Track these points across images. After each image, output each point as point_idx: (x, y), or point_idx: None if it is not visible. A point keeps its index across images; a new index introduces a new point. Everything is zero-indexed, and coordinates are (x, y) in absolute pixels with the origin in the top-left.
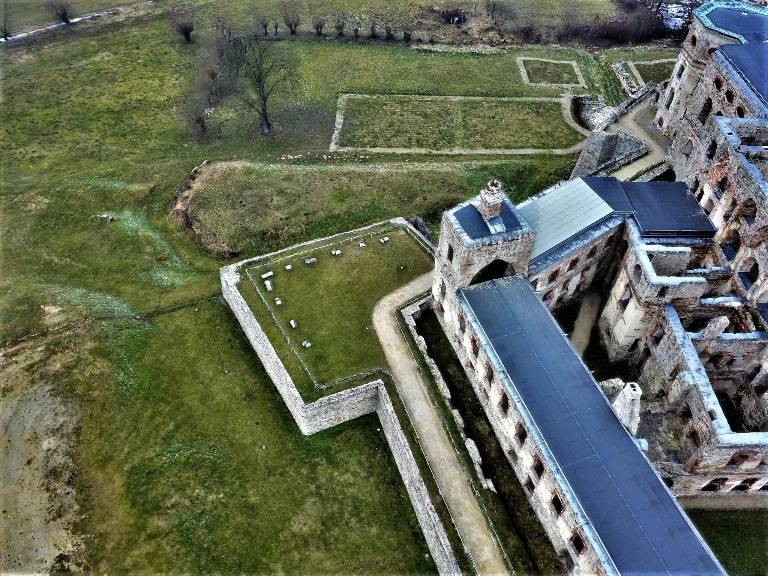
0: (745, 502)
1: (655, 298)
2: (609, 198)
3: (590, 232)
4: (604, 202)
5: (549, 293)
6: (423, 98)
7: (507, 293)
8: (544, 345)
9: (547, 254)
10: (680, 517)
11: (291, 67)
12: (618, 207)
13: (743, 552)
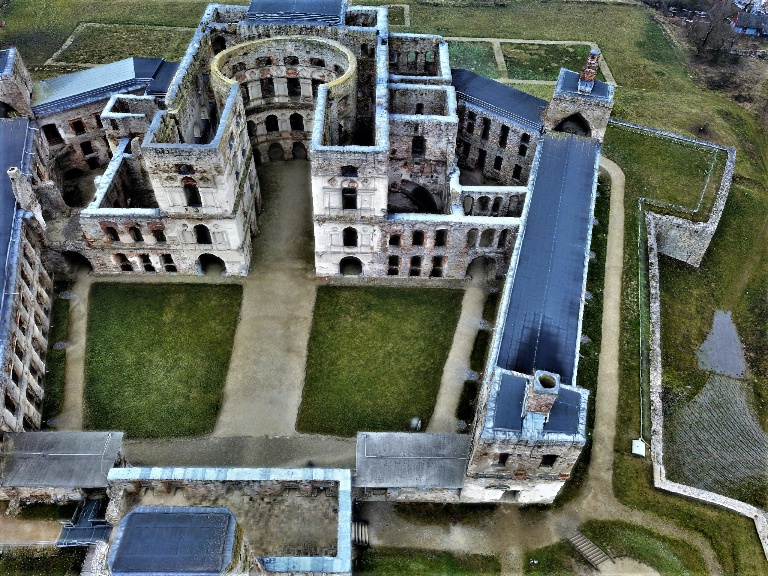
0: (155, 279)
1: (113, 131)
2: (140, 70)
3: (109, 92)
4: (133, 72)
5: (91, 145)
6: (154, 28)
7: (4, 126)
8: (2, 157)
9: (59, 104)
10: (5, 249)
11: (52, 1)
12: (140, 76)
13: (125, 305)
